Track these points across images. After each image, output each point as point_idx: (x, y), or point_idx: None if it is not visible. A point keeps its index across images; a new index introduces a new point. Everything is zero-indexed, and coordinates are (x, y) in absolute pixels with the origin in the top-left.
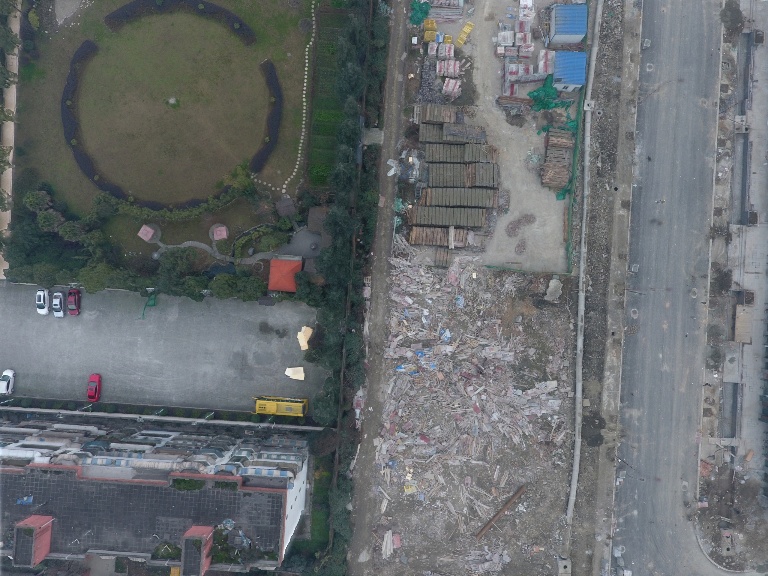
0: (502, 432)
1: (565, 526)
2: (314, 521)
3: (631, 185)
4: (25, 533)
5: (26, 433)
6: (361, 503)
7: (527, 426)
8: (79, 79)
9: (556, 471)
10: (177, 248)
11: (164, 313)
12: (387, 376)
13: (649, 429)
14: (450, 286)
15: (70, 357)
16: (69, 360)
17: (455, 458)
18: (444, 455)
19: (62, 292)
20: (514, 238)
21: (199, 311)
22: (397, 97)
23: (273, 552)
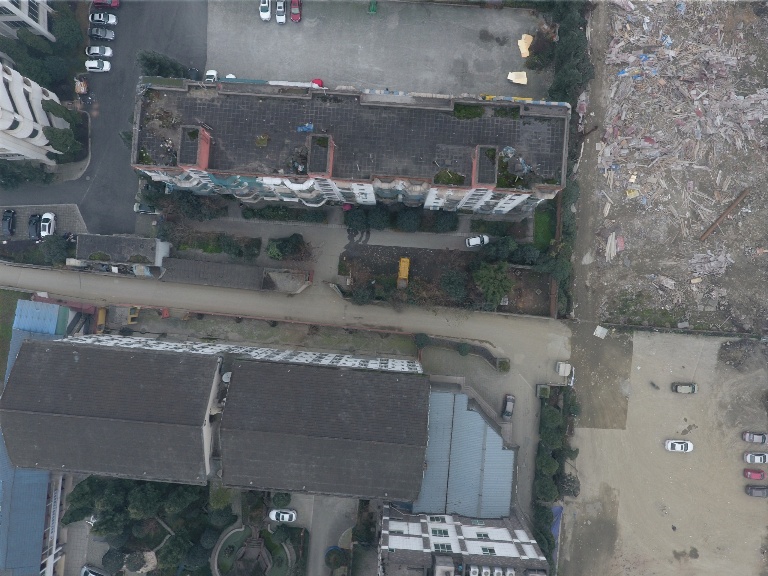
0: (724, 137)
1: None
2: (537, 224)
3: None
4: (318, 143)
5: None
6: (584, 206)
7: (750, 129)
8: None
9: None
10: None
11: (384, 21)
12: (609, 82)
13: None
14: None
15: (291, 64)
16: (290, 67)
17: (677, 163)
18: (668, 157)
19: None
20: None
21: (419, 19)
22: None
23: (553, 179)
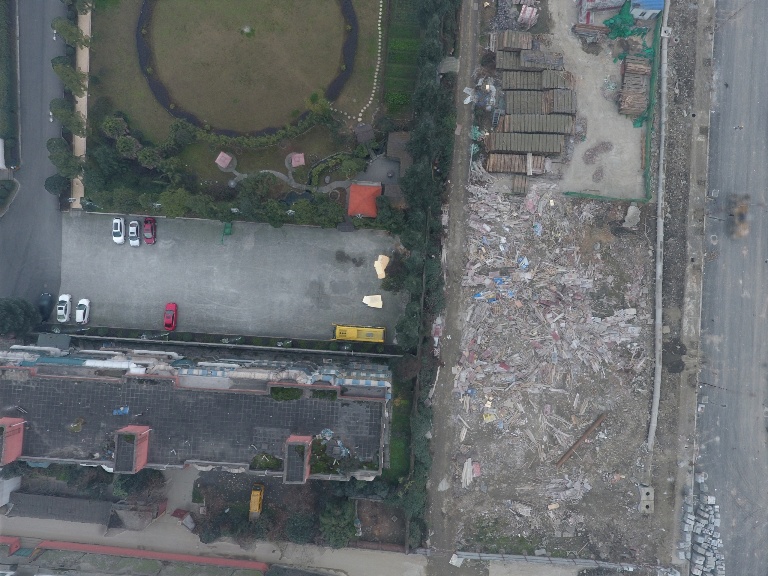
0: (581, 360)
1: (647, 453)
2: (393, 450)
3: (709, 111)
4: (126, 440)
5: (110, 354)
6: (440, 431)
7: (607, 353)
8: (154, 9)
9: (636, 398)
10: (258, 172)
11: (240, 242)
12: (465, 304)
13: (730, 355)
14: (527, 214)
15: (146, 287)
16: (145, 290)
17: (534, 386)
18: (524, 382)
19: (138, 221)
20: (591, 165)
21: (275, 240)
22: (473, 26)
23: (372, 462)
